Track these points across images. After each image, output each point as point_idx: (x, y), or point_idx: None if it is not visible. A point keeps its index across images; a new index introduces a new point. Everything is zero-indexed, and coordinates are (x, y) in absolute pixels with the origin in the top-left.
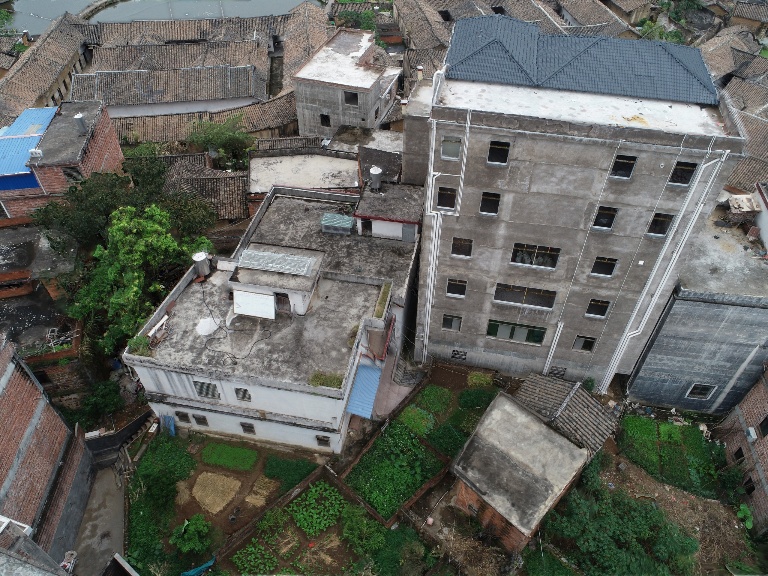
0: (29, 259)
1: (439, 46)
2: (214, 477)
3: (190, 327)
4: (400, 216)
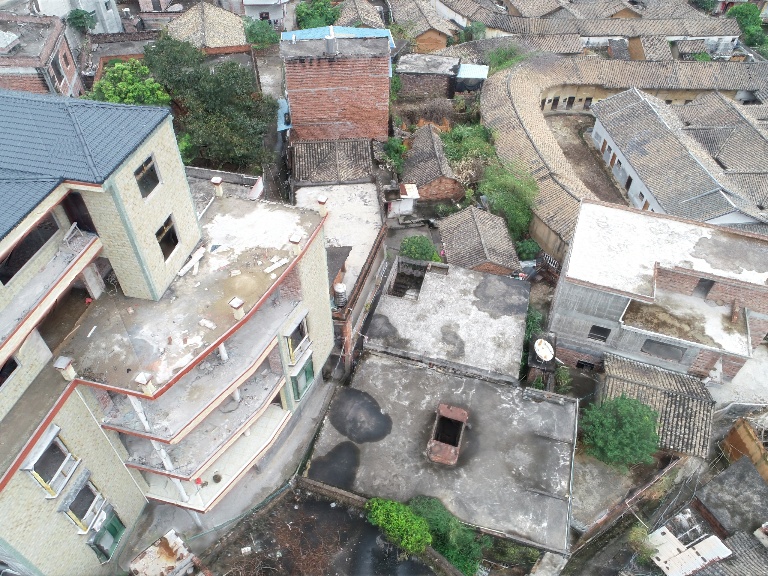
0: None
1: None
2: None
3: None
4: None
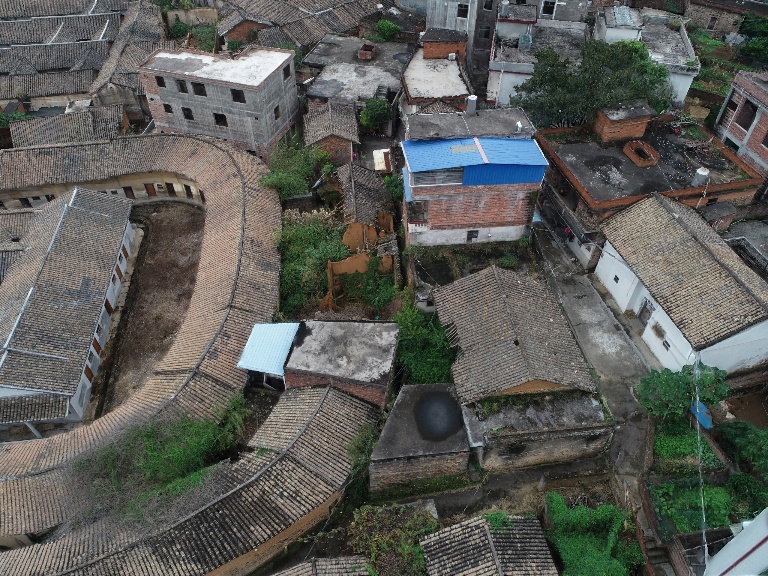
0: (605, 158)
1: (94, 72)
2: (692, 113)
3: (660, 59)
4: (532, 11)
